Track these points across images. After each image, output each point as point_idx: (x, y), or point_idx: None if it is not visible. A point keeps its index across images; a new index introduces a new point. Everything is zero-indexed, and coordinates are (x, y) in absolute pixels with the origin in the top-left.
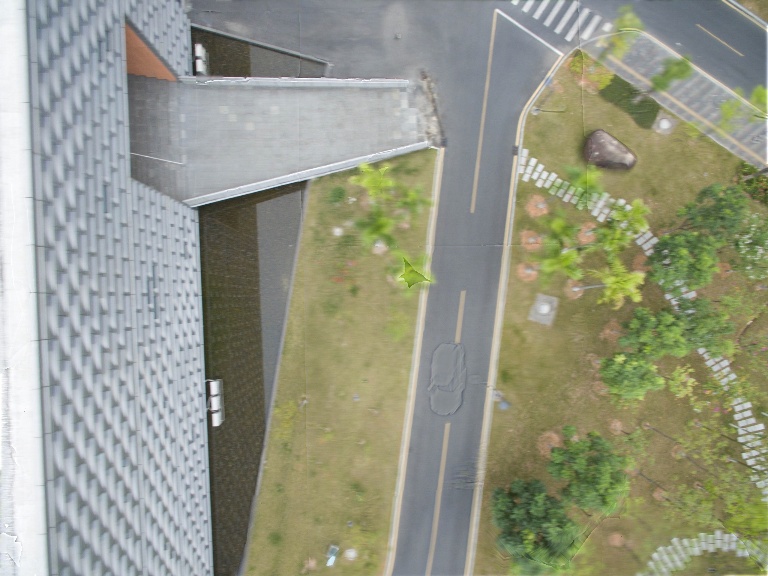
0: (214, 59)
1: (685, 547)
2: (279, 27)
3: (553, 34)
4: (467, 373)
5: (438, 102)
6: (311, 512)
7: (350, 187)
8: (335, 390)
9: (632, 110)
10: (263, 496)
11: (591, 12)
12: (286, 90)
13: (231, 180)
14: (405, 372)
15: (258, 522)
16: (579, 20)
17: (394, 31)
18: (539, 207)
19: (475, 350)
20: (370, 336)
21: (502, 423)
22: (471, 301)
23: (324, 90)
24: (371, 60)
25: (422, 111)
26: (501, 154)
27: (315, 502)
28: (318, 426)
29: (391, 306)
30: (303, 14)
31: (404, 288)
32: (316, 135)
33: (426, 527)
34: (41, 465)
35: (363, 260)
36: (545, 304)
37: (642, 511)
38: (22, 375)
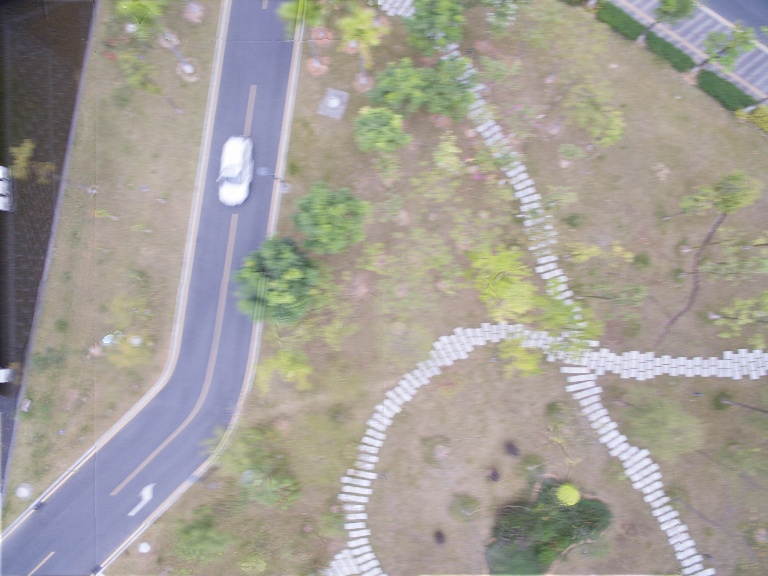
0: None
1: (468, 336)
2: None
3: None
4: (255, 165)
5: None
6: (98, 298)
7: None
8: (124, 180)
9: None
10: (51, 282)
11: None
12: None
13: None
14: (193, 163)
15: (46, 308)
16: None
17: None
18: (330, 3)
19: (264, 143)
20: (160, 128)
21: (288, 214)
22: (261, 95)
23: None
24: None
25: None
26: None
27: (102, 288)
28: (106, 214)
29: (181, 99)
30: None
31: (194, 81)
32: None
33: (211, 315)
34: None
35: (153, 53)
36: (334, 98)
37: (425, 300)
38: None
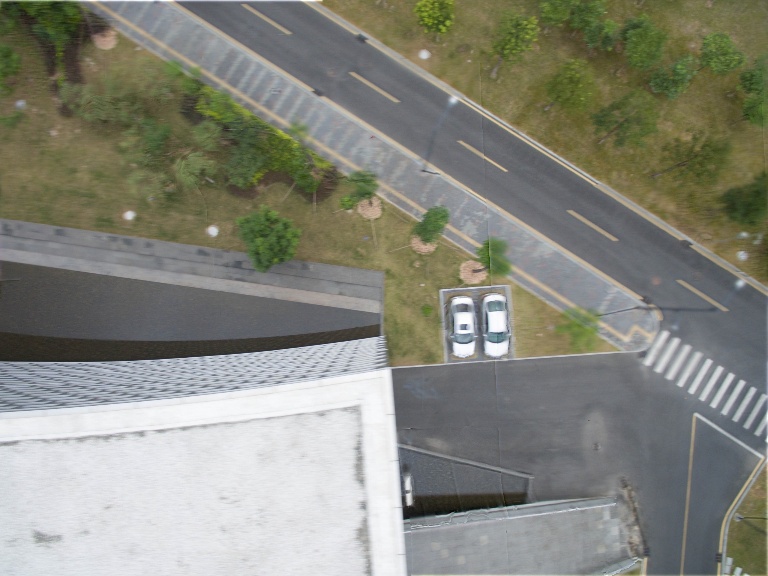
0: (418, 482)
1: None
2: (479, 441)
3: (753, 437)
4: None
5: (639, 511)
6: None
7: None
8: None
9: None
10: None
11: None
12: None
13: None
14: None
15: None
16: None
17: (593, 441)
18: None
19: None
20: None
21: None
22: None
23: None
24: (571, 471)
25: (624, 521)
26: (705, 563)
27: None
28: None
29: None
30: (502, 427)
31: None
32: (524, 561)
33: None
34: None
35: None
36: None
37: None
38: None
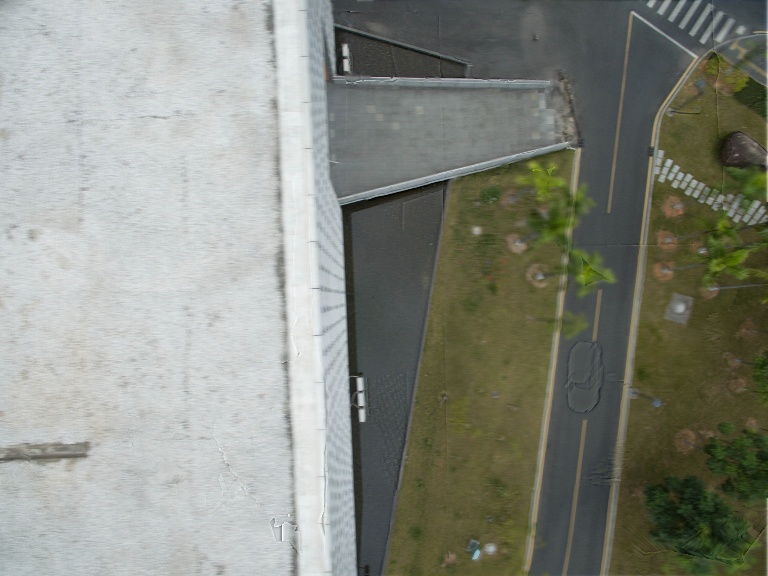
0: (357, 59)
1: None
2: (419, 28)
3: (688, 37)
4: (604, 371)
5: (575, 103)
6: (451, 507)
7: (490, 186)
8: (474, 387)
9: (766, 112)
10: (404, 491)
11: (725, 15)
12: (430, 90)
13: (380, 179)
14: (543, 369)
15: (399, 516)
16: (713, 23)
17: (532, 32)
18: (675, 208)
19: (612, 348)
20: (509, 334)
21: (639, 420)
22: (608, 300)
23: (467, 90)
24: (509, 61)
25: (559, 112)
26: (637, 155)
27: (455, 497)
28: (458, 422)
29: (530, 304)
30: (443, 15)
31: (543, 287)
32: (459, 135)
33: (564, 522)
34: (323, 456)
35: (503, 259)
36: (681, 303)
37: None
38: (304, 369)
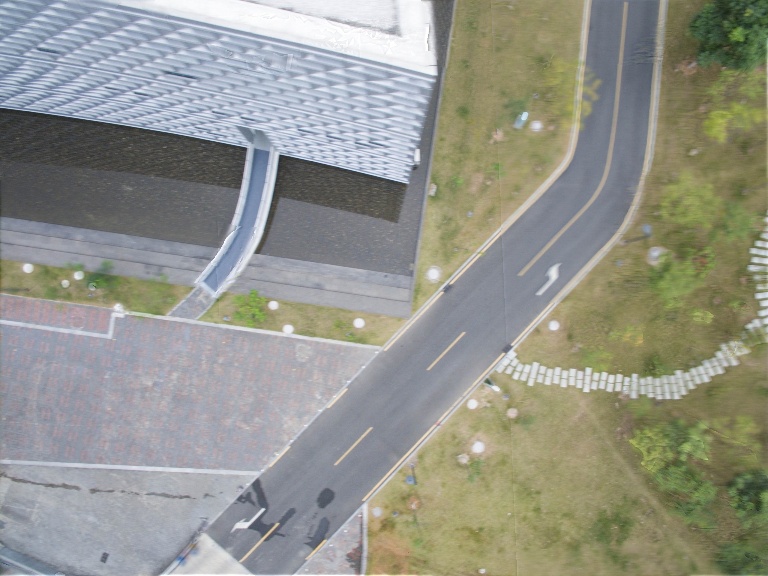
0: None
1: None
2: None
3: None
4: None
5: None
6: (498, 85)
7: None
8: None
9: None
10: (452, 70)
11: None
12: None
13: None
14: None
15: (447, 96)
16: None
17: None
18: None
19: None
20: None
21: (679, 0)
22: None
23: None
24: None
25: None
26: None
27: (502, 76)
28: (503, 4)
29: None
30: None
31: None
32: None
33: (609, 99)
34: None
35: None
36: None
37: None
38: None
